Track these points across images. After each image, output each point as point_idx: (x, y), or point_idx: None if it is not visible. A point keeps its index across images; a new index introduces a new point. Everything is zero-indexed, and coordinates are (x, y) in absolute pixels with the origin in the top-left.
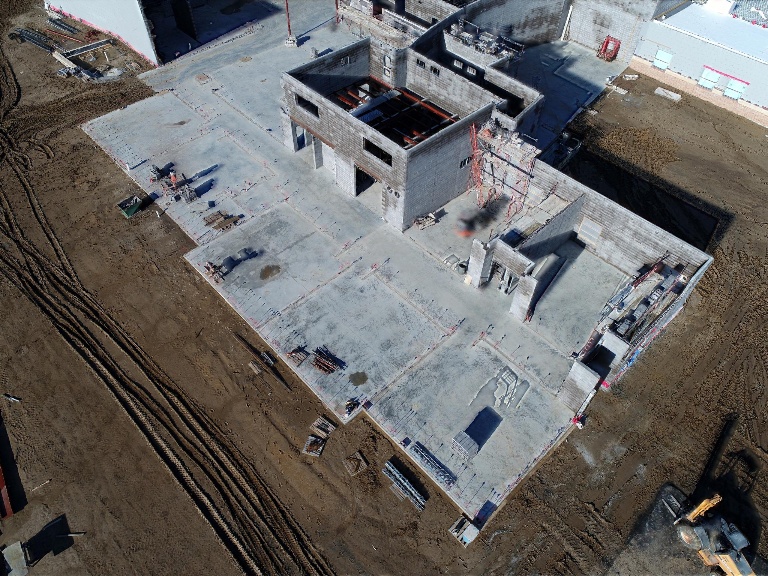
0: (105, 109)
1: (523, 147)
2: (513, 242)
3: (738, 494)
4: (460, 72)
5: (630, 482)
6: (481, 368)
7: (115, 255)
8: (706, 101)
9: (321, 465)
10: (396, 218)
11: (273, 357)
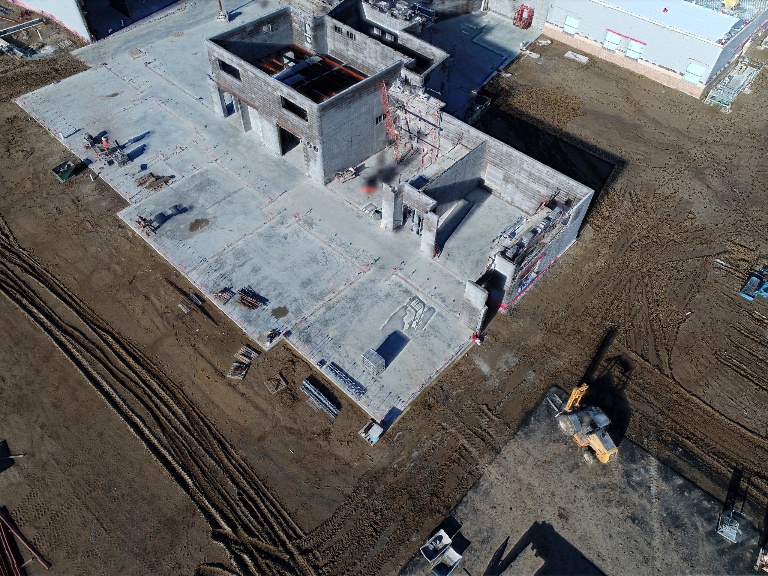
0: (39, 84)
1: (429, 101)
2: (421, 186)
3: (613, 390)
4: (380, 39)
5: (520, 386)
6: (392, 298)
7: (50, 216)
8: (611, 62)
9: (244, 386)
10: (318, 172)
11: (201, 298)
